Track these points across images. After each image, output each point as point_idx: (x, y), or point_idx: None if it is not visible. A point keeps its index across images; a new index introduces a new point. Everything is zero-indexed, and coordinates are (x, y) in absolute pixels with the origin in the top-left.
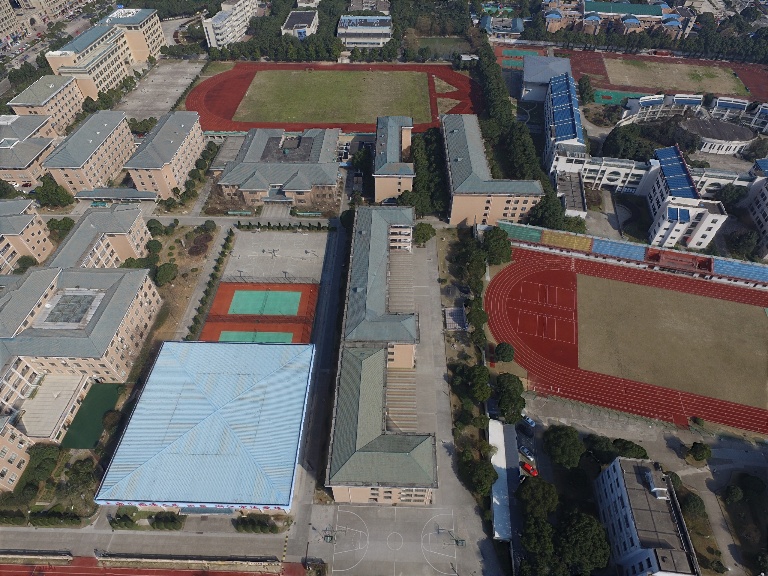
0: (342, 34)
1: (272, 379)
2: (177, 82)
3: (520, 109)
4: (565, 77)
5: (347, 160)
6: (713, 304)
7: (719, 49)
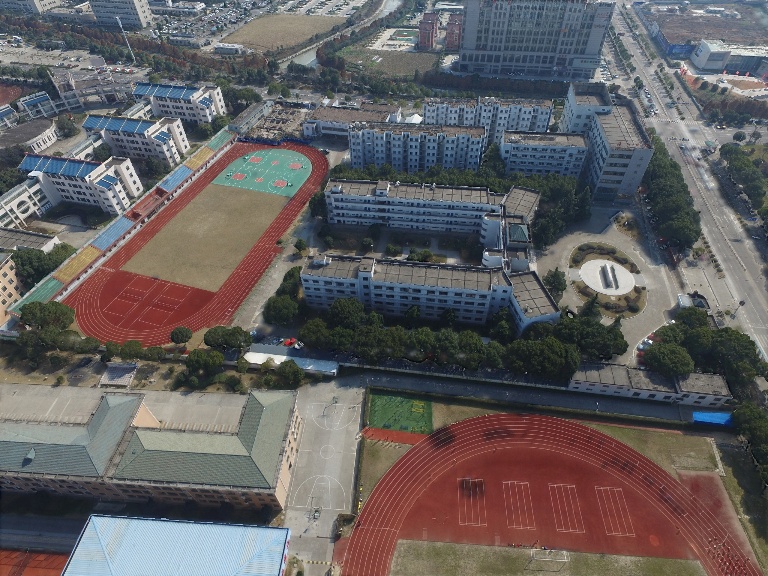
0: None
1: (122, 570)
2: None
3: None
4: None
5: None
6: (195, 204)
7: None
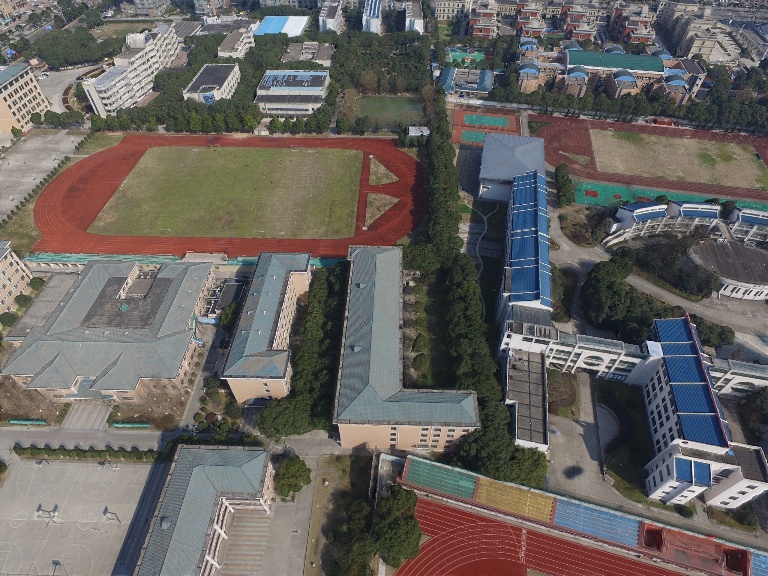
0: (262, 97)
1: None
2: (39, 166)
3: (475, 214)
4: (533, 178)
5: (215, 315)
6: None
7: (736, 120)
